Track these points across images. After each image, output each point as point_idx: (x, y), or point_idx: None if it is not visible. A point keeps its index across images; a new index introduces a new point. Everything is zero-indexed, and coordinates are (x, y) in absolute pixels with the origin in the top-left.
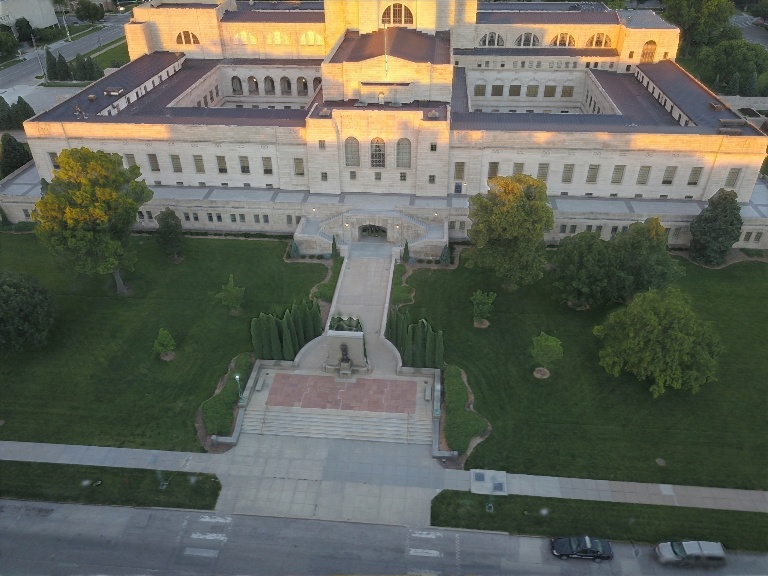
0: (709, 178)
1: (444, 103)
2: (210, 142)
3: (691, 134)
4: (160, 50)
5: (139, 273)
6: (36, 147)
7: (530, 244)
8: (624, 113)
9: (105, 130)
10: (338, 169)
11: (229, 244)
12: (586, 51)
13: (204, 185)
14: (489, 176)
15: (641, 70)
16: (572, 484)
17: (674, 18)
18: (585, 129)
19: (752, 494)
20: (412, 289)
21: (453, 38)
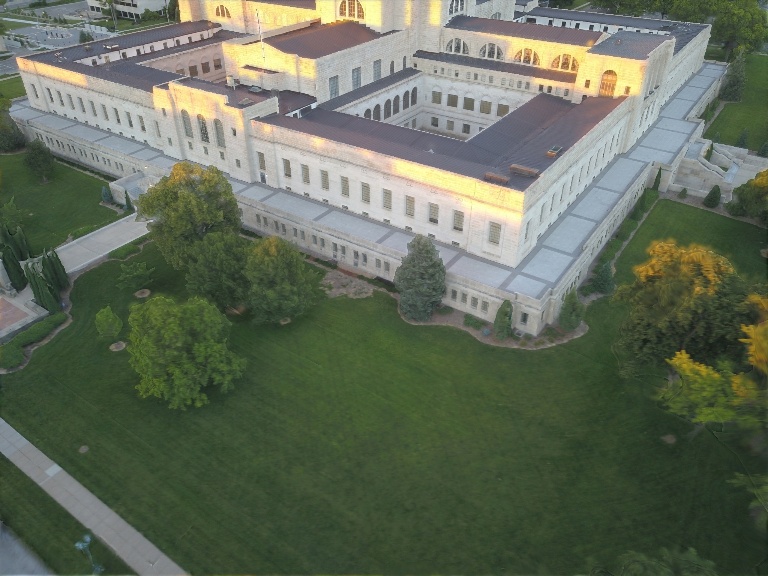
0: (469, 226)
1: (311, 97)
2: (106, 95)
3: (446, 171)
4: (206, 19)
5: (10, 184)
6: (24, 78)
7: (174, 230)
8: (473, 141)
9: (54, 72)
10: (177, 137)
11: (88, 181)
12: (549, 72)
13: (110, 131)
14: (286, 172)
15: (581, 102)
16: (5, 431)
17: None
18: (372, 144)
19: (102, 508)
20: (136, 250)
21: (419, 39)
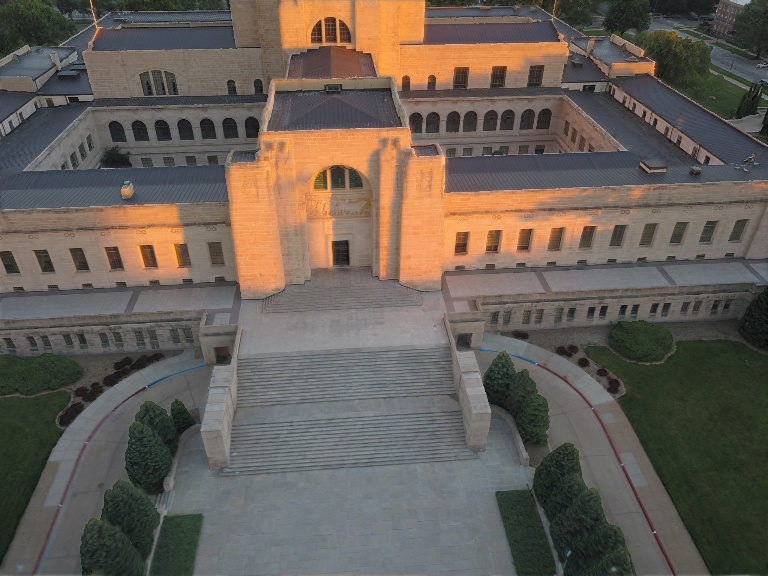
0: None
1: None
2: None
3: None
4: None
5: None
6: None
7: None
8: None
9: None
10: None
11: None
12: None
13: None
14: None
15: None
16: (764, 97)
17: (161, 10)
18: None
19: None
20: None
21: None
